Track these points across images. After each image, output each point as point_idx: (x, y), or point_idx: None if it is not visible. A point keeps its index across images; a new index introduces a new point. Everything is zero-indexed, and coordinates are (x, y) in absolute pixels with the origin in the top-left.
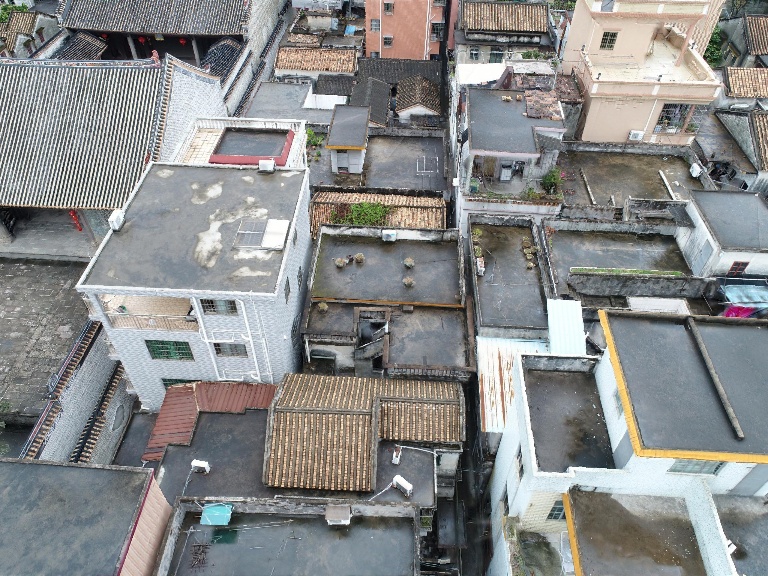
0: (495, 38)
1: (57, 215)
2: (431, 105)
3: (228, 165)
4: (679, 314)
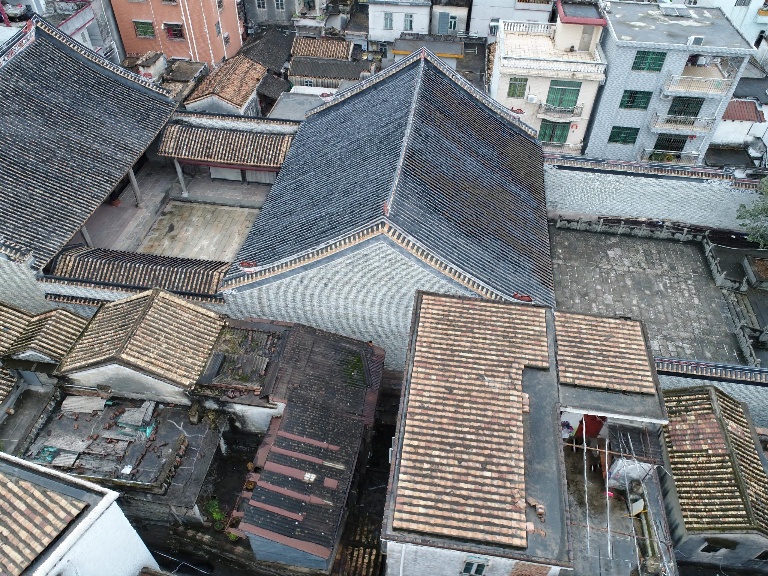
0: None
1: None
2: None
3: None
4: None
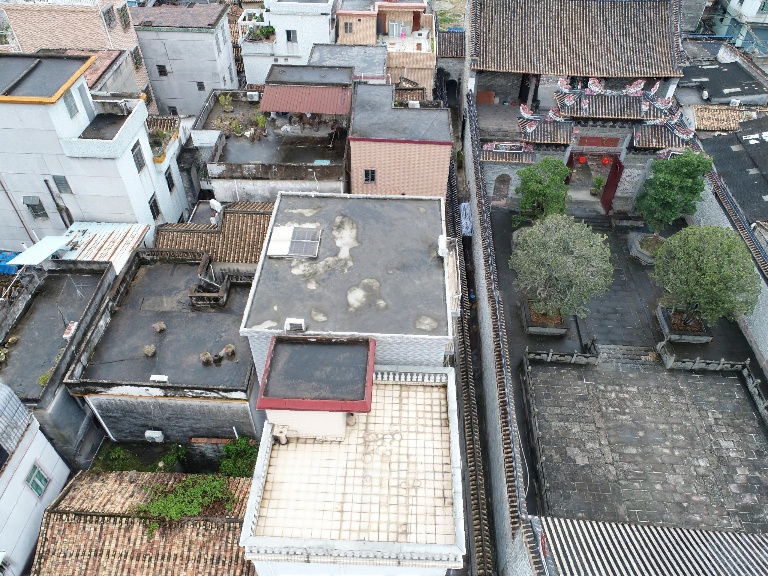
0: None
1: None
2: None
3: (347, 333)
4: (5, 96)
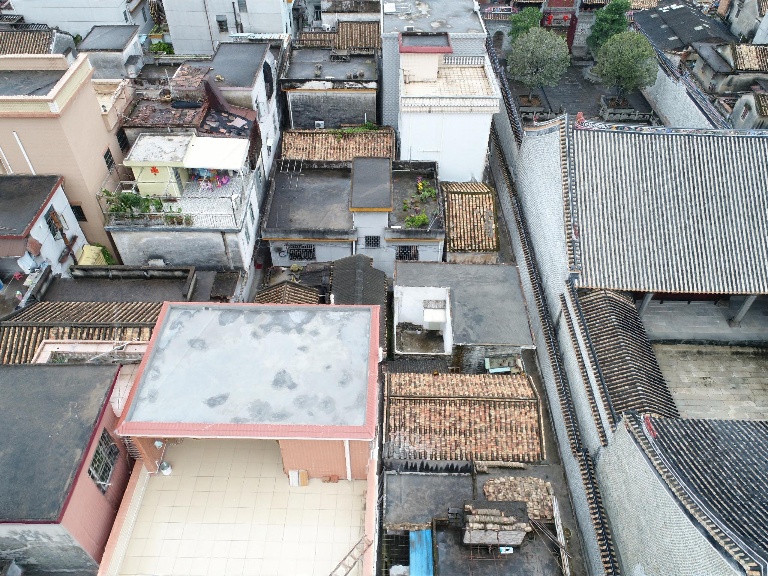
0: (148, 273)
1: None
2: (267, 299)
3: None
4: None
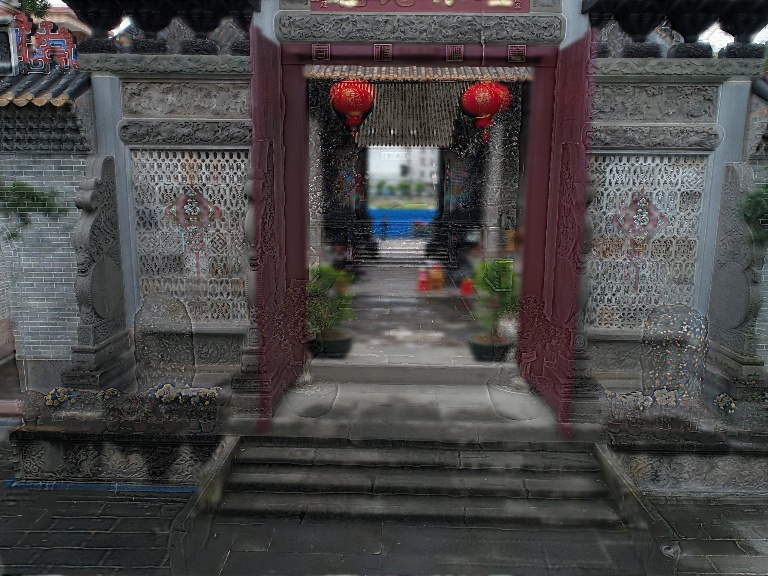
0: None
1: (382, 217)
2: None
3: None
4: None
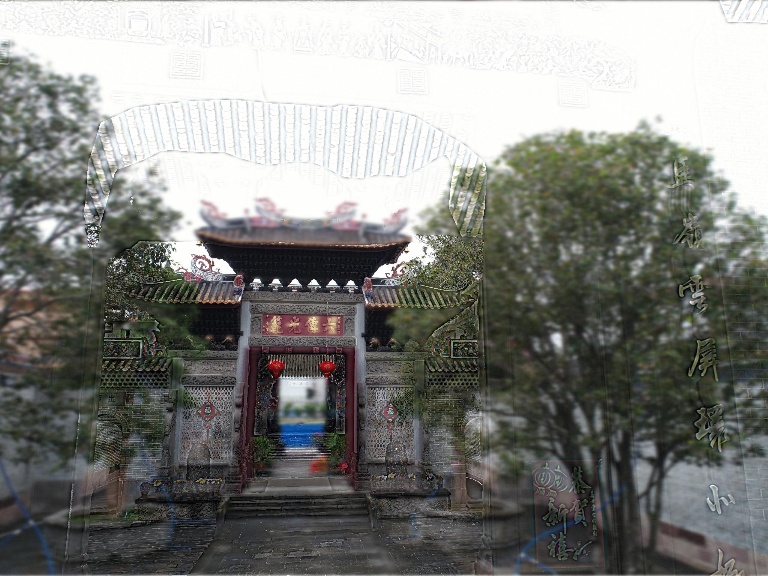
0: None
1: (288, 432)
2: None
3: None
4: None
